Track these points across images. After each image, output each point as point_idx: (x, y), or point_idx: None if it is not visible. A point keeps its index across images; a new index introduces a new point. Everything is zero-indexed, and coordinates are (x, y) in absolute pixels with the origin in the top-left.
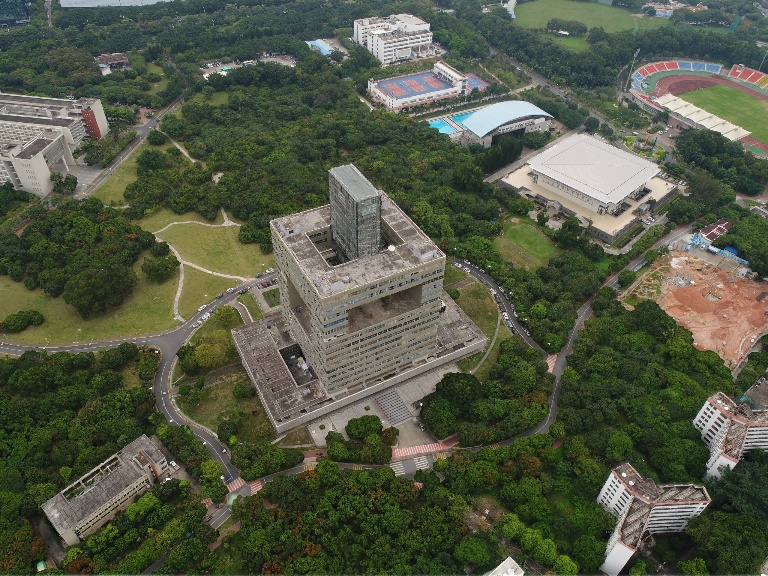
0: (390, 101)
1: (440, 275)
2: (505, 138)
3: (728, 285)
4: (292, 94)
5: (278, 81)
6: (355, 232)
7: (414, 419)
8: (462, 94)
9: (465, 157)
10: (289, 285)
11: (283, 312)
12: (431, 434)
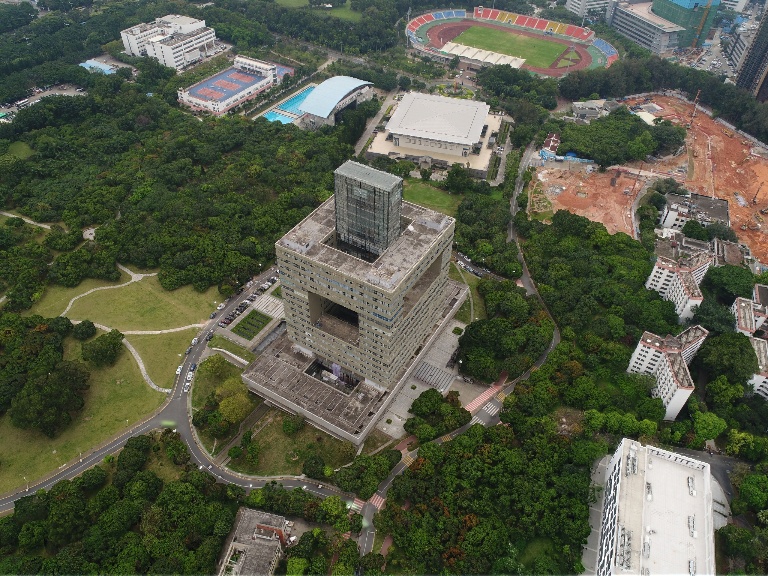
0: (214, 106)
1: (451, 238)
2: (347, 113)
3: (586, 182)
4: (101, 124)
5: (75, 114)
6: (385, 222)
7: (458, 377)
8: (275, 83)
9: (324, 140)
10: (309, 301)
11: (291, 334)
12: (481, 383)
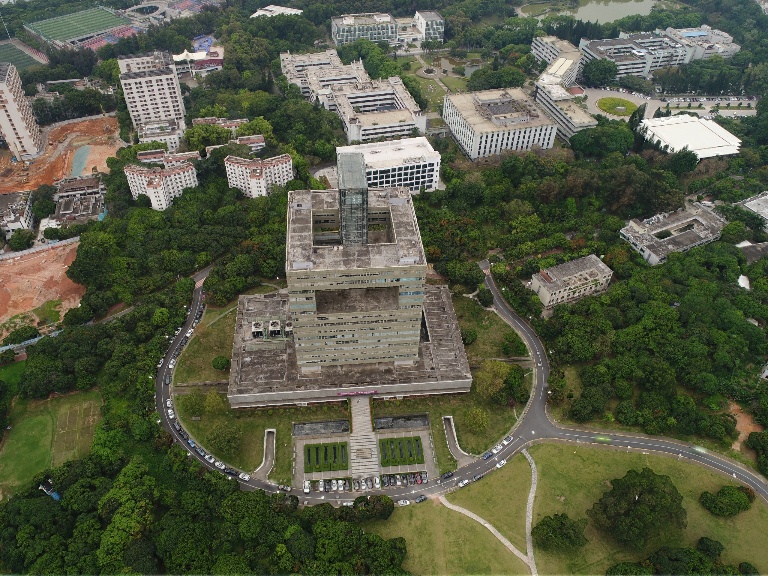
0: None
1: None
2: None
3: None
4: None
5: None
6: None
7: None
8: None
9: None
10: None
11: None
12: None
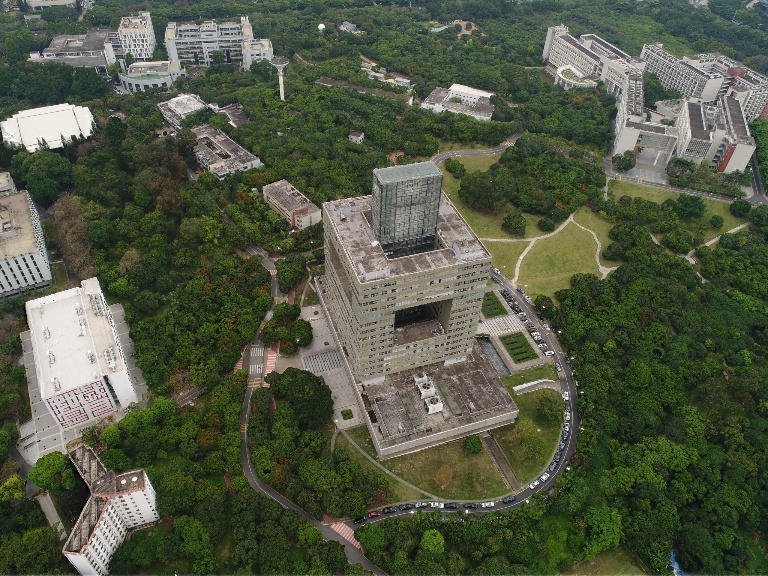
0: None
1: None
2: None
3: None
4: None
5: None
6: None
7: None
8: None
9: None
10: None
11: None
12: None
